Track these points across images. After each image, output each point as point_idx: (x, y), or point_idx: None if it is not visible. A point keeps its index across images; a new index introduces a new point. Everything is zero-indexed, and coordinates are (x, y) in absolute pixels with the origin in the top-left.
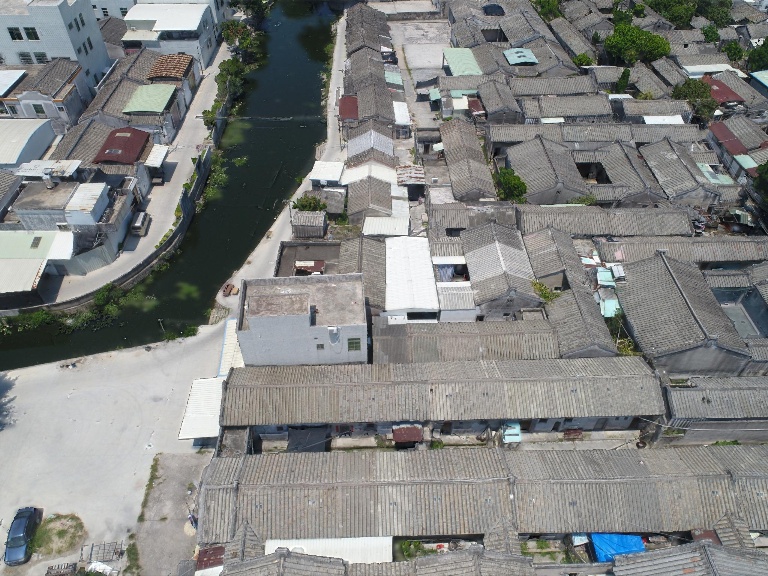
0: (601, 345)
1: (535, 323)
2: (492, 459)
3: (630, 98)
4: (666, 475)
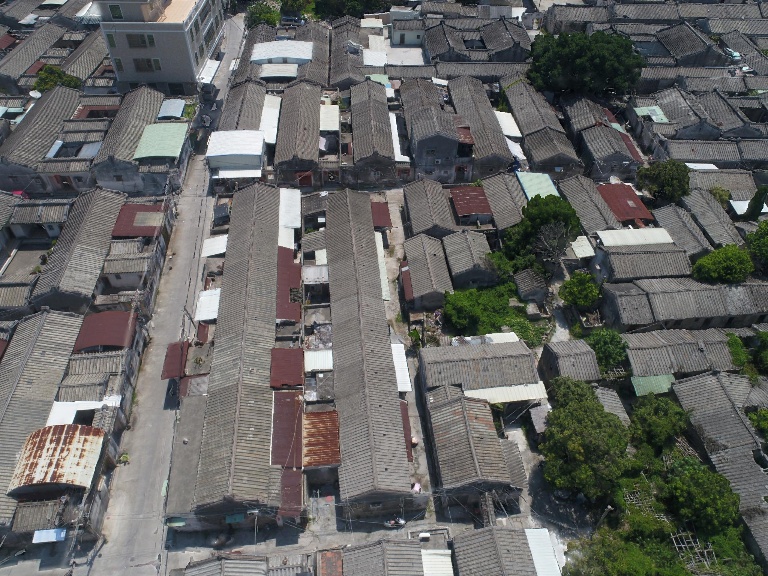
0: (732, 31)
1: (765, 45)
2: (767, 11)
3: (737, 199)
4: (701, 5)
